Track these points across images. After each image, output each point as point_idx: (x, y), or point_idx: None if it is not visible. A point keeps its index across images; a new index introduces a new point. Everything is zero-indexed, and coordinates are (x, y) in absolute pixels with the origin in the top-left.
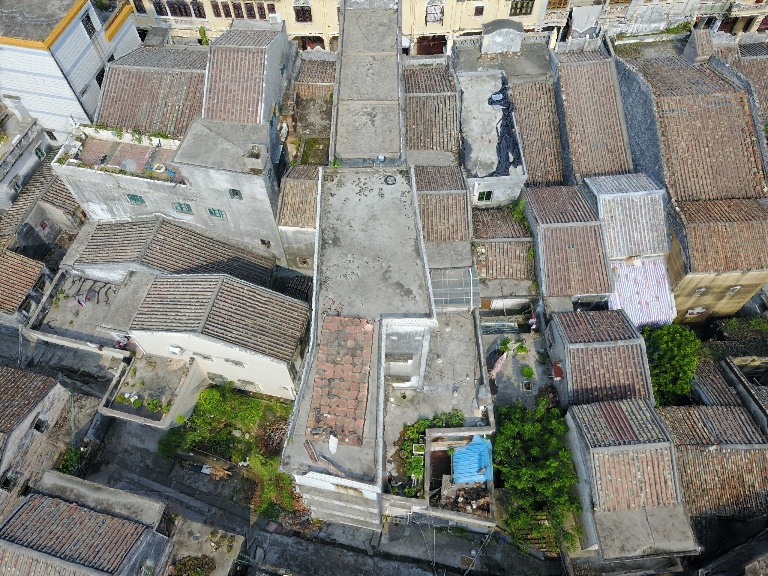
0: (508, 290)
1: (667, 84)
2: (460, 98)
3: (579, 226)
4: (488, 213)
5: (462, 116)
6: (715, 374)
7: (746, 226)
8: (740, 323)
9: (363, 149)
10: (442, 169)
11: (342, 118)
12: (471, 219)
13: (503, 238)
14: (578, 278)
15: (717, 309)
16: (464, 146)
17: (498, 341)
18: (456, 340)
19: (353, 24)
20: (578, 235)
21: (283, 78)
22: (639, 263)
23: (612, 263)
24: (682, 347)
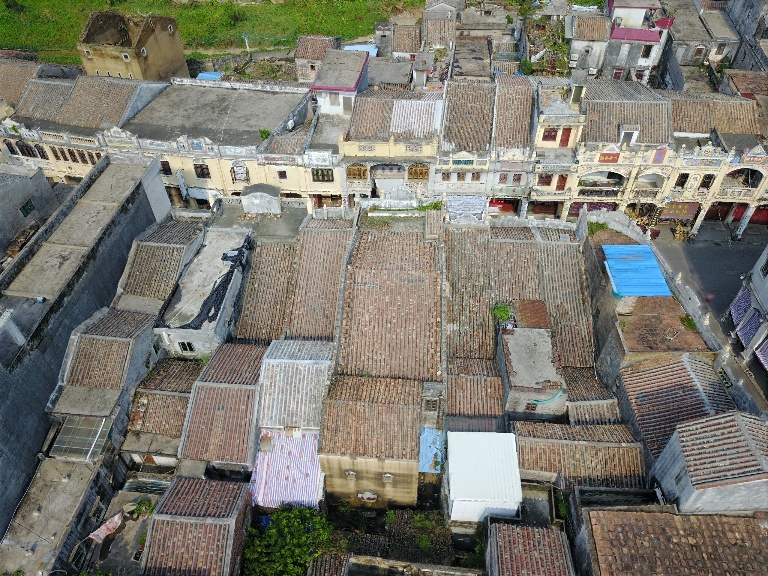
0: (156, 446)
1: (378, 257)
2: (196, 251)
3: (234, 388)
4: (184, 364)
5: (191, 268)
6: (334, 572)
7: (385, 409)
8: (410, 516)
9: (34, 289)
10: (138, 316)
11: (37, 258)
12: (127, 368)
13: (168, 391)
14: (218, 443)
15: (391, 497)
16: (175, 296)
17: (138, 500)
18: (67, 493)
19: (109, 176)
20: (231, 397)
21: (29, 217)
22: (299, 435)
23: (270, 431)
24: (296, 535)
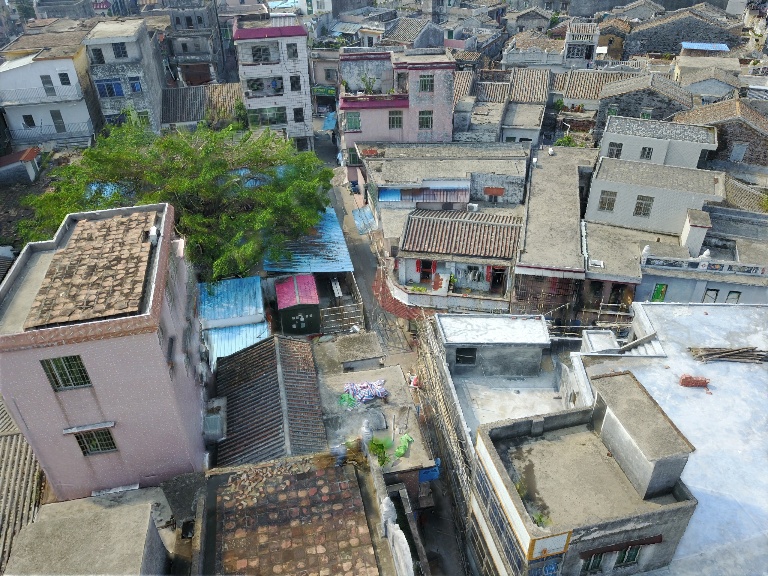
0: None
1: None
2: None
3: None
4: None
5: None
6: None
7: None
8: None
9: None
10: None
11: None
12: (631, 8)
13: None
14: None
15: None
16: None
17: None
18: None
19: None
20: None
21: None
22: None
23: None
24: None
